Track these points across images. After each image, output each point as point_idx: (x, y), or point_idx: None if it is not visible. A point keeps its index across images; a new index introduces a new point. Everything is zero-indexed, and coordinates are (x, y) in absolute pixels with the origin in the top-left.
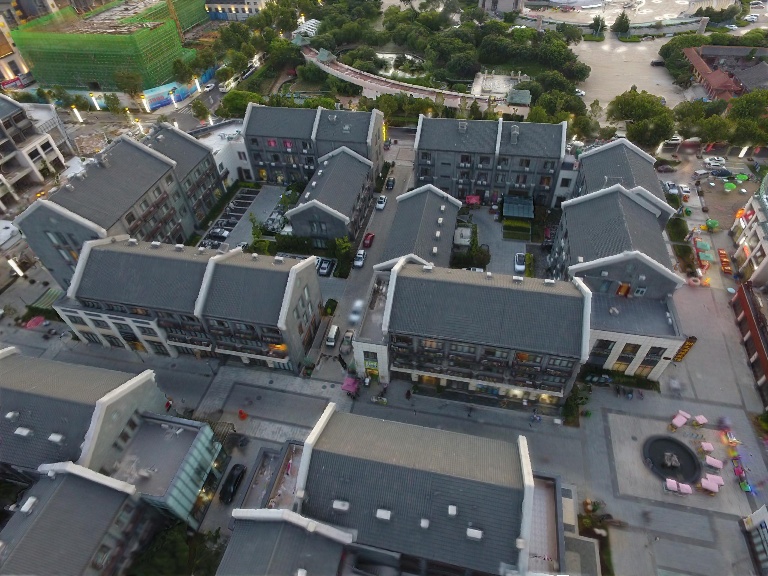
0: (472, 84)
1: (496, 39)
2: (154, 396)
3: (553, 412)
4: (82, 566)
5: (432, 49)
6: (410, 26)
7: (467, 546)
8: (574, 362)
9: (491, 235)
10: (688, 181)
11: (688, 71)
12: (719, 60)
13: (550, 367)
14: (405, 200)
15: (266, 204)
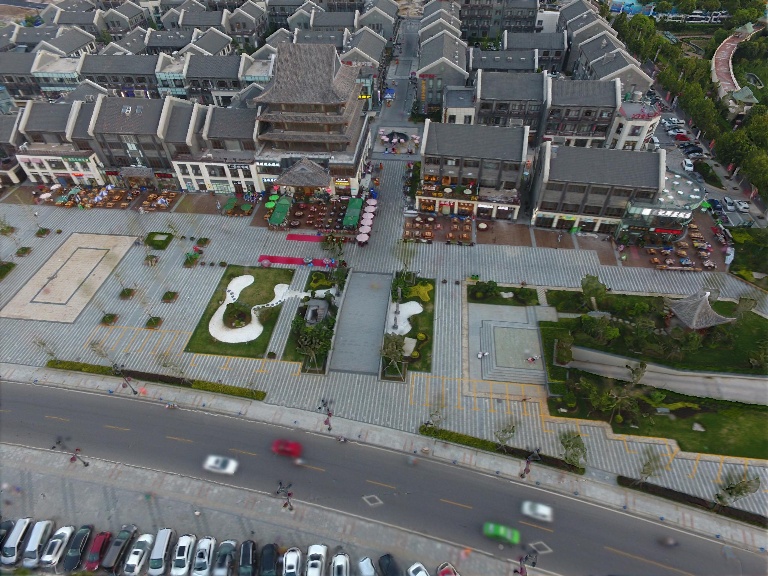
0: None
1: None
2: (389, 29)
3: None
4: (336, 25)
5: None
6: None
7: None
8: None
9: None
10: None
11: None
12: None
13: None
14: None
15: None
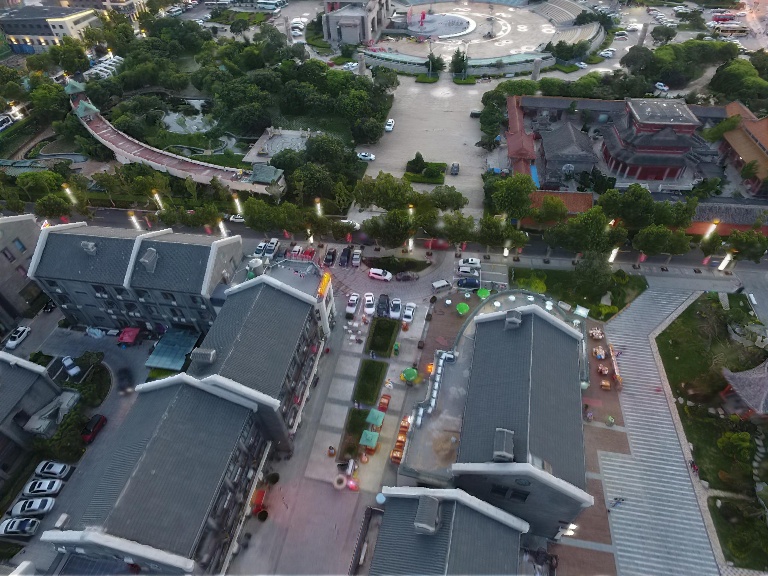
0: None
1: (298, 85)
2: None
3: None
4: None
5: (220, 99)
6: (208, 68)
7: None
8: None
9: (127, 393)
10: (425, 295)
11: (500, 127)
12: (541, 112)
13: None
14: None
15: None
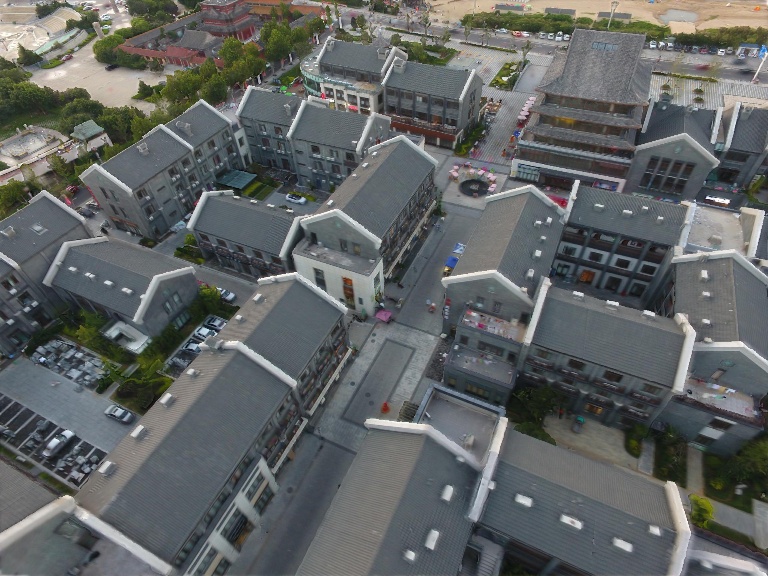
0: None
1: None
2: None
3: (435, 219)
4: (570, 453)
5: None
6: None
7: (552, 230)
8: (432, 173)
9: None
10: None
11: None
12: (147, 46)
13: (427, 187)
14: (198, 222)
15: (38, 383)
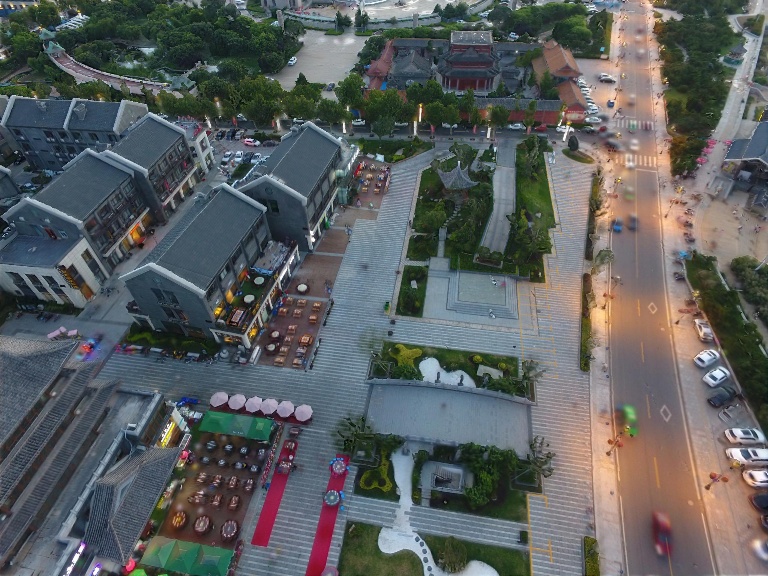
0: (185, 74)
1: (224, 33)
2: None
3: None
4: None
5: (161, 42)
6: (154, 21)
7: None
8: None
9: None
10: None
11: None
12: (409, 51)
13: None
14: None
15: None
